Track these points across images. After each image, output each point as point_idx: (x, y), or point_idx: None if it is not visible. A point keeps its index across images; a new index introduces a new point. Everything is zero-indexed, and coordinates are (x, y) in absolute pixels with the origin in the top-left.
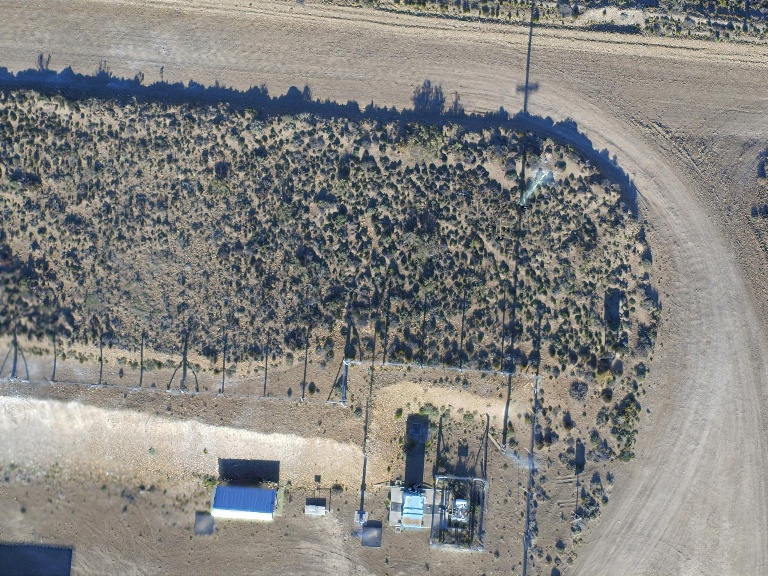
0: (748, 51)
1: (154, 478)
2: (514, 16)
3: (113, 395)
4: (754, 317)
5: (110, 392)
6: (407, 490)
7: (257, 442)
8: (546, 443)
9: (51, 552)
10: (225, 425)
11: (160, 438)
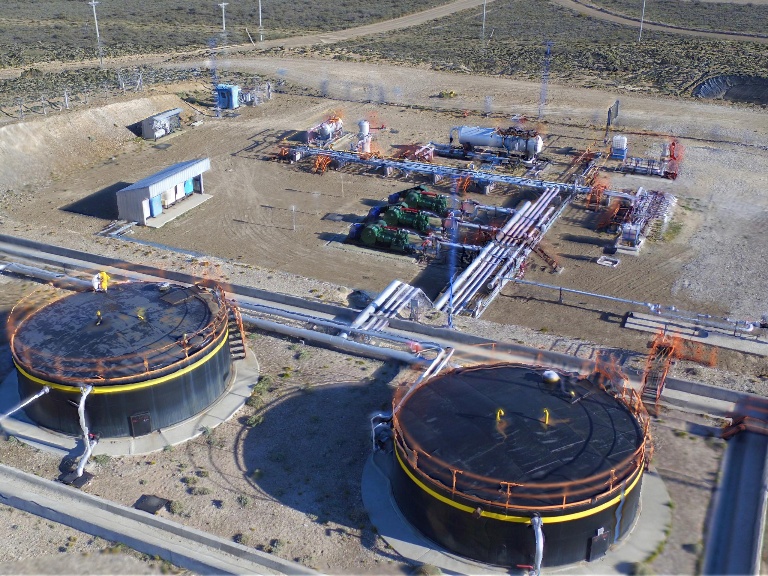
0: (109, 60)
1: (111, 154)
2: (7, 68)
3: (36, 117)
4: (231, 59)
5: (33, 117)
6: (217, 104)
7: (132, 111)
8: (234, 83)
9: (111, 187)
10: (107, 104)
11: (87, 130)
